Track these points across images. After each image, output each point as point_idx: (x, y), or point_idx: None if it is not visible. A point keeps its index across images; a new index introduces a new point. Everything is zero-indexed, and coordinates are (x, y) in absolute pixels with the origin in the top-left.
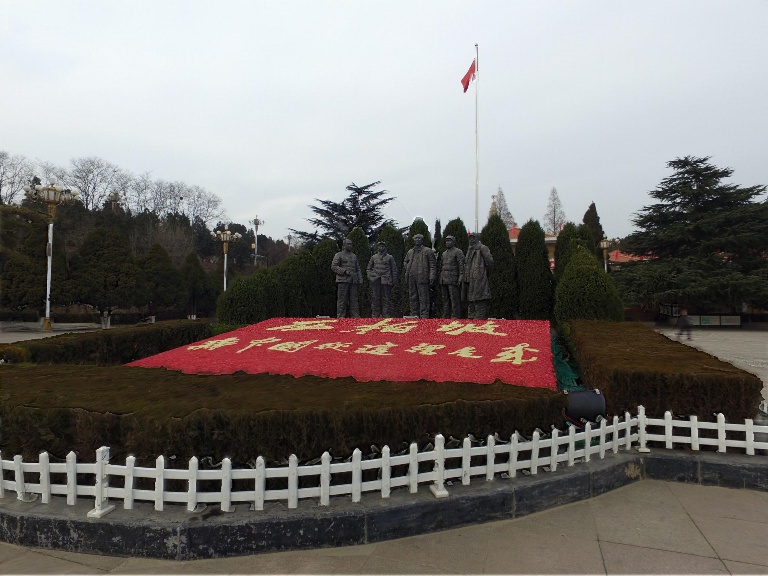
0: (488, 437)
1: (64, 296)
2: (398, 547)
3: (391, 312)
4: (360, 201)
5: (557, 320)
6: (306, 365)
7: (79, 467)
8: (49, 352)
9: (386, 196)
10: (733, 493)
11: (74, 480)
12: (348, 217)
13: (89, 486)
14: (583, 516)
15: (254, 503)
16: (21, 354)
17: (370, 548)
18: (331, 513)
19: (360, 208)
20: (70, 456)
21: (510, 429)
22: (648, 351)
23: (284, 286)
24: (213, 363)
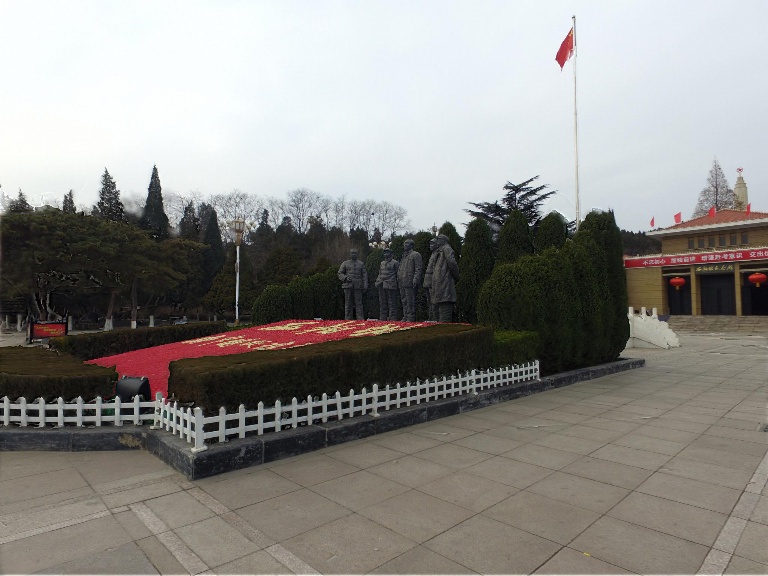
0: None
1: (247, 303)
2: None
3: (419, 315)
4: (517, 199)
5: None
6: None
7: None
8: (81, 341)
9: (546, 191)
10: (153, 466)
11: None
12: (504, 217)
13: None
14: (25, 457)
15: None
16: (61, 342)
17: None
18: None
19: (517, 206)
20: None
21: (31, 396)
22: None
23: (316, 292)
24: (164, 353)
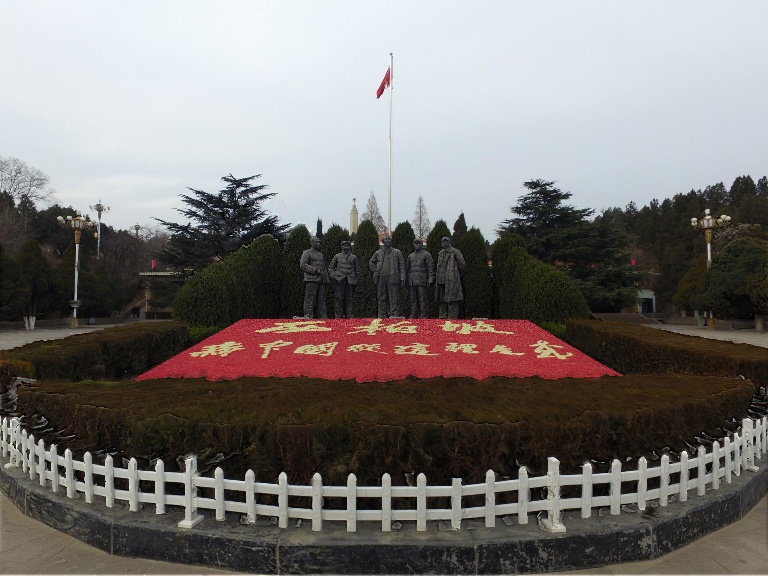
0: (763, 418)
1: None
2: (766, 517)
3: None
4: (238, 194)
5: (530, 319)
6: (369, 368)
7: (530, 482)
8: (53, 365)
9: (267, 191)
10: None
11: (529, 496)
12: (224, 210)
13: (539, 501)
14: None
15: (676, 495)
16: (26, 369)
17: (751, 521)
18: (723, 495)
19: (238, 201)
20: (525, 471)
21: None
22: (706, 344)
23: (239, 284)
24: (255, 370)
